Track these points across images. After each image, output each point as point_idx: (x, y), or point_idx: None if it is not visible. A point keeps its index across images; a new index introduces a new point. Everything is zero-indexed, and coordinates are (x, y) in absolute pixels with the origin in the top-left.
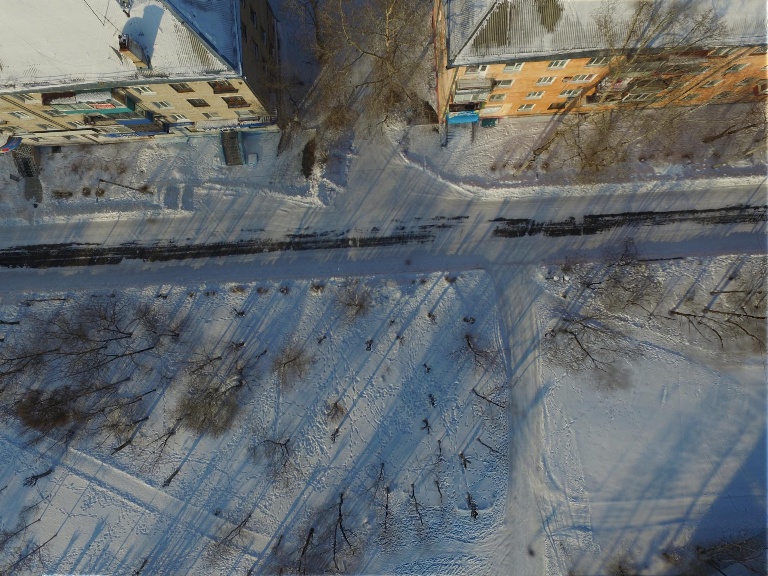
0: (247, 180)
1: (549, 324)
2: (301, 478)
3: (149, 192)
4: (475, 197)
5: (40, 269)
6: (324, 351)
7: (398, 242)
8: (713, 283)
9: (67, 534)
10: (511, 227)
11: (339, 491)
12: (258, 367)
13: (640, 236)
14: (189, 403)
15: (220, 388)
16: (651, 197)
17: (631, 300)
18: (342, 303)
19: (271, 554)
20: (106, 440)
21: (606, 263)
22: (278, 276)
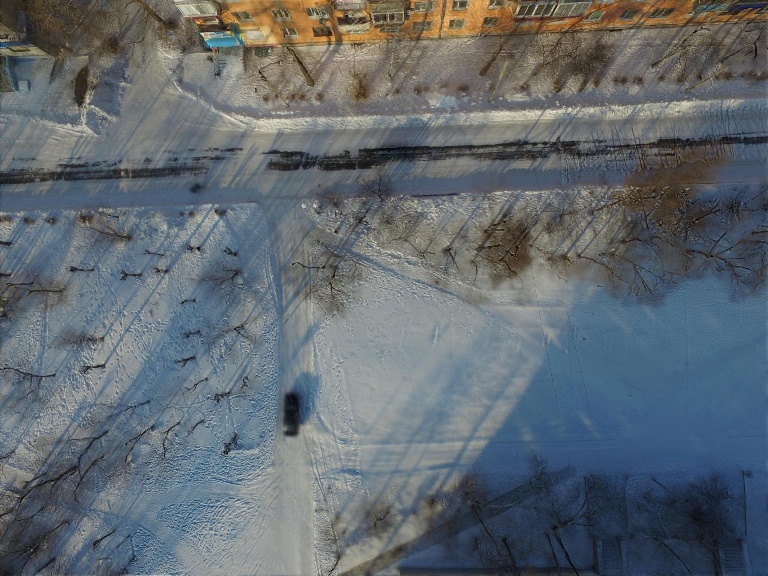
0: (19, 107)
1: (320, 260)
2: (67, 414)
3: None
4: (248, 128)
5: None
6: (92, 284)
7: (171, 174)
8: (487, 220)
9: None
10: (285, 160)
11: (104, 428)
12: (22, 298)
13: (416, 171)
14: None
15: None
16: (427, 131)
17: (404, 237)
18: None
19: (34, 491)
20: None
21: (378, 198)
22: (48, 206)
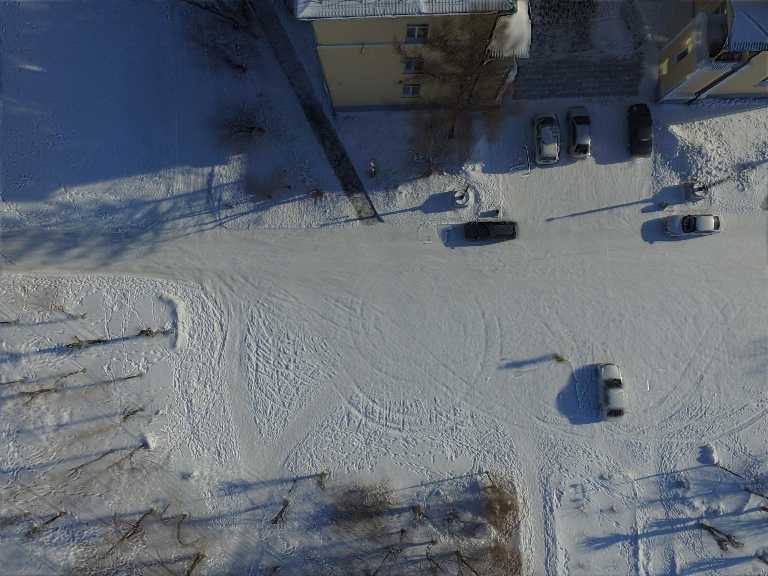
0: None
1: None
2: (129, 568)
3: None
4: None
5: None
6: None
7: None
8: None
9: None
10: None
11: None
12: None
13: None
14: None
15: None
16: None
17: None
18: None
19: None
20: None
21: None
22: None
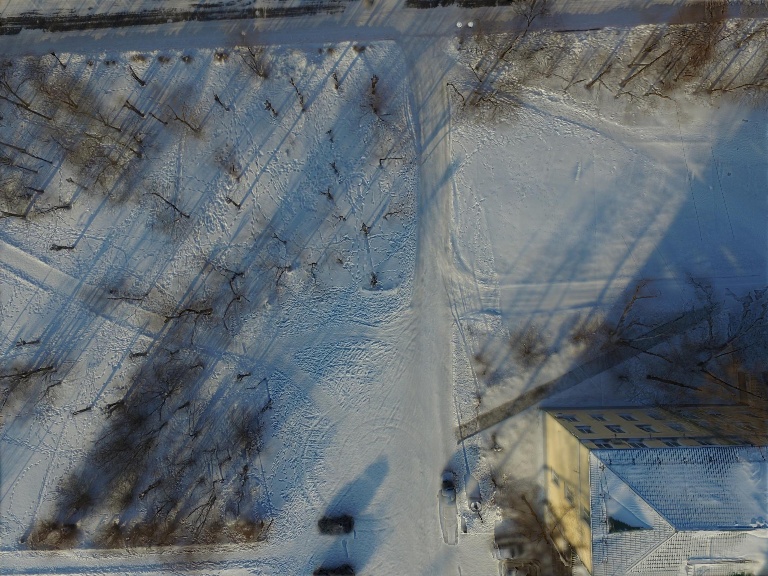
0: None
1: (460, 97)
2: (201, 257)
3: None
4: None
5: None
6: (227, 124)
7: (306, 13)
8: (631, 55)
9: None
10: None
11: (239, 270)
12: (157, 137)
13: (557, 8)
14: (86, 176)
15: (119, 162)
16: None
17: (546, 73)
18: (247, 74)
19: (168, 335)
20: None
21: (520, 33)
22: (181, 46)
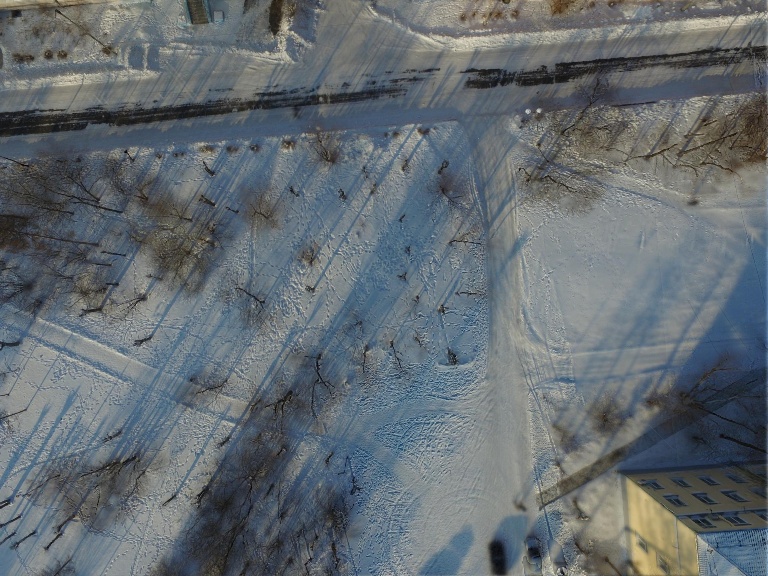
0: (213, 38)
1: (524, 173)
2: (278, 340)
3: (113, 51)
4: (446, 48)
5: (3, 137)
6: (297, 209)
7: (369, 97)
8: (687, 126)
9: (37, 408)
10: (483, 78)
11: (317, 352)
12: (230, 226)
13: (612, 82)
14: (160, 267)
15: (192, 251)
16: (622, 43)
17: (606, 146)
18: (314, 160)
19: (249, 419)
20: (75, 309)
21: (579, 109)
22: (248, 135)
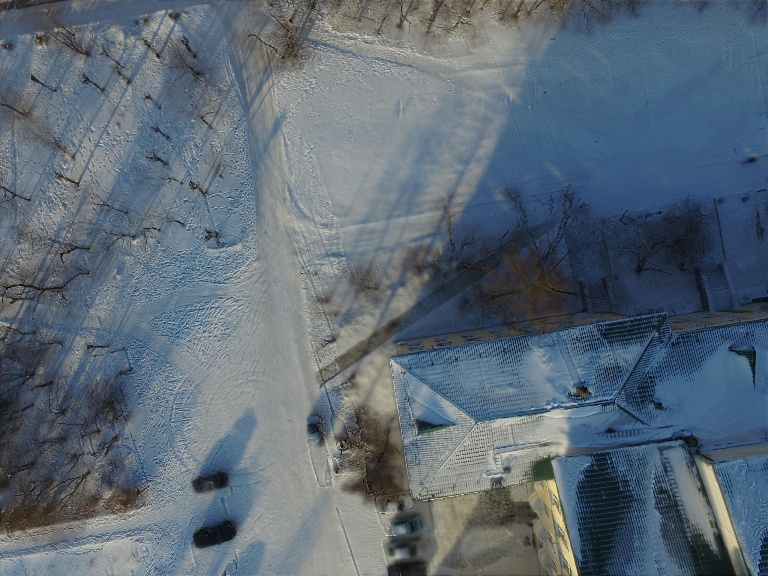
0: None
1: (279, 51)
2: (47, 237)
3: None
4: None
5: None
6: (56, 105)
7: None
8: None
9: None
10: None
11: (85, 245)
12: None
13: None
14: None
15: None
16: None
17: (357, 17)
18: (69, 54)
19: (23, 318)
20: None
21: None
22: (3, 35)
